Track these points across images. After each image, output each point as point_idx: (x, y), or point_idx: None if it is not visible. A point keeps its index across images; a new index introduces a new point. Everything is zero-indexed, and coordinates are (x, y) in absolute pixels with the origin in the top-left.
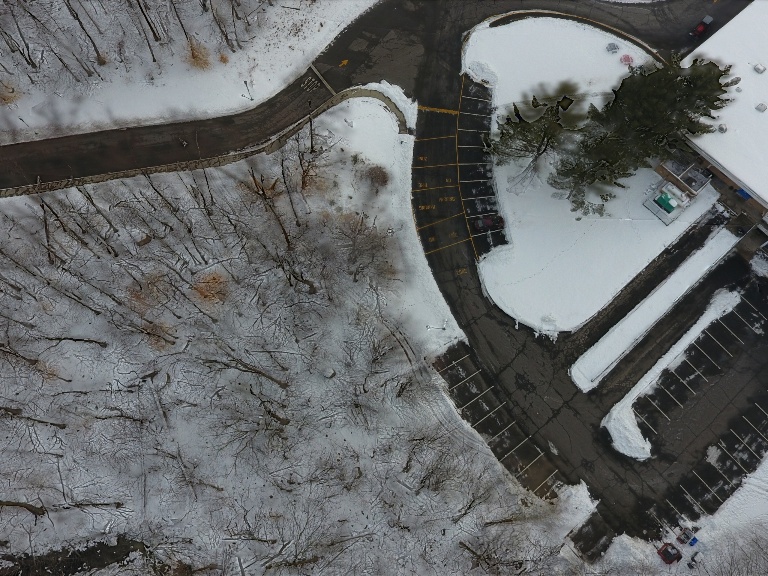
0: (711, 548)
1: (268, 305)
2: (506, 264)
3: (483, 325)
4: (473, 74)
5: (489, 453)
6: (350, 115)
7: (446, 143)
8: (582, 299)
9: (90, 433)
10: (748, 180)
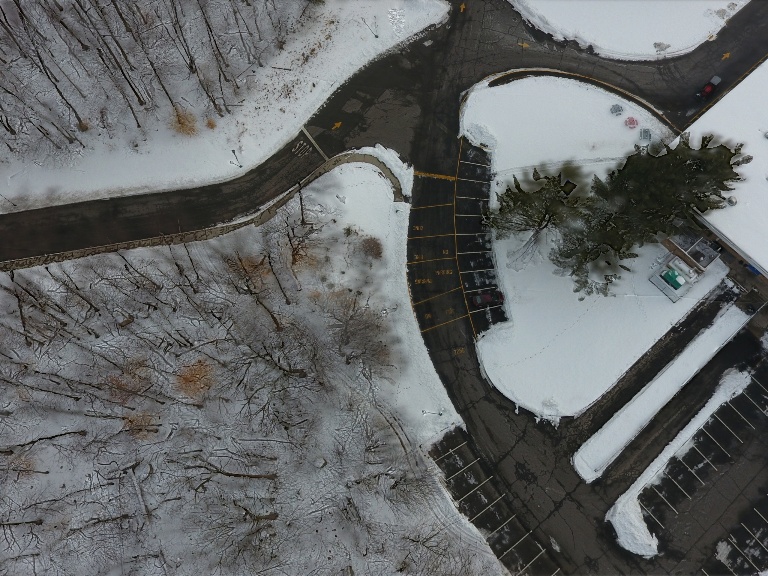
0: None
1: (256, 390)
2: (506, 343)
3: (481, 409)
4: (471, 137)
5: (488, 550)
6: (343, 183)
7: (443, 211)
8: (585, 381)
9: (68, 529)
10: (759, 258)
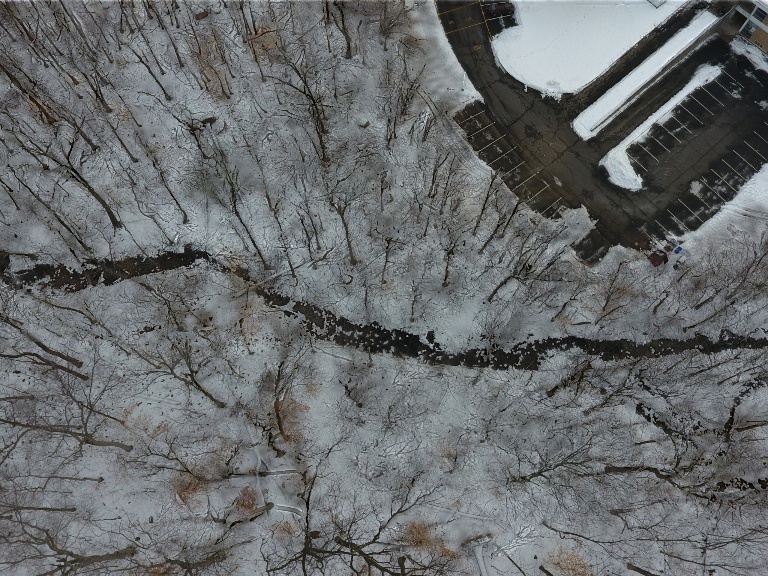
0: (693, 254)
1: (310, 67)
2: (516, 41)
3: (496, 88)
4: None
5: (503, 184)
6: None
7: None
8: (583, 67)
9: None
10: None
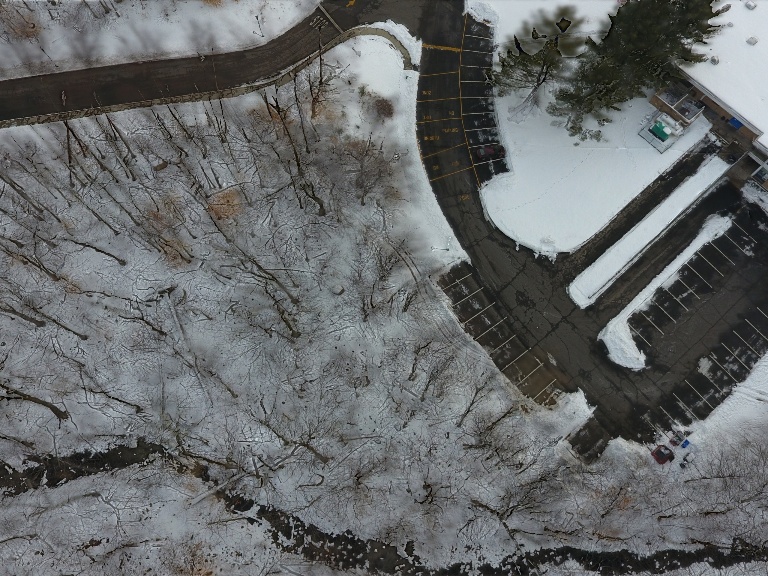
0: (702, 449)
1: (279, 226)
2: (507, 190)
3: (485, 247)
4: (475, 14)
5: (491, 363)
6: None
7: (449, 78)
8: (580, 222)
9: (111, 344)
10: (739, 107)
